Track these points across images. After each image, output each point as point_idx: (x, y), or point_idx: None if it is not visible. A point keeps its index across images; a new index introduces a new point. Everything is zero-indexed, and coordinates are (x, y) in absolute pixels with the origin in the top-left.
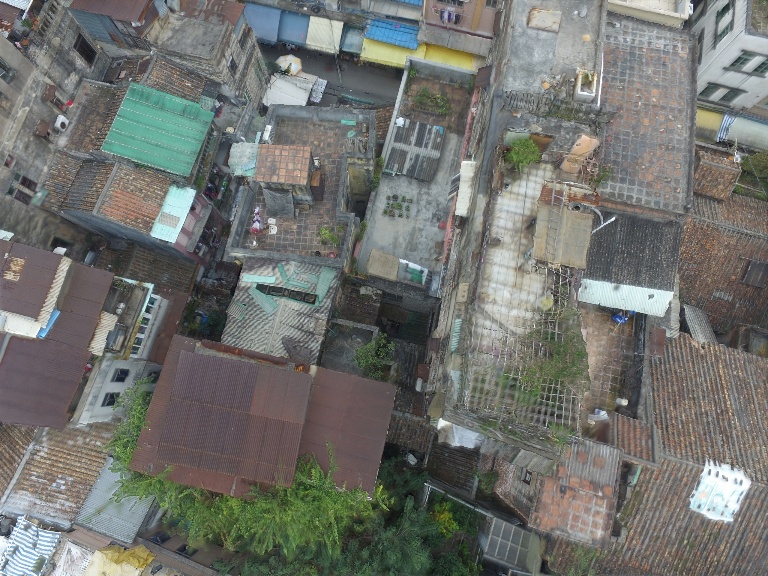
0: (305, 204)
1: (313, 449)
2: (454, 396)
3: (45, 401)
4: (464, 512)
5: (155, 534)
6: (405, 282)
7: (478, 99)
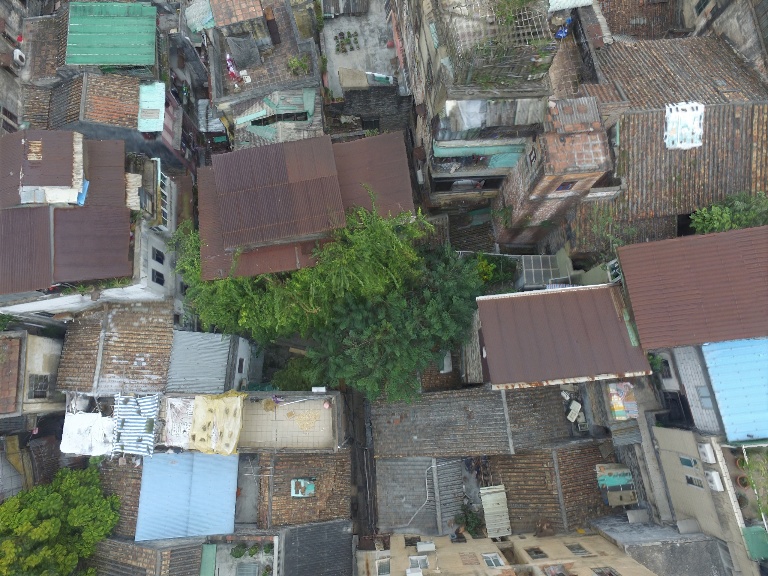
0: (267, 49)
1: (352, 203)
2: (450, 75)
3: (106, 255)
4: (496, 262)
5: None
6: (377, 85)
7: None
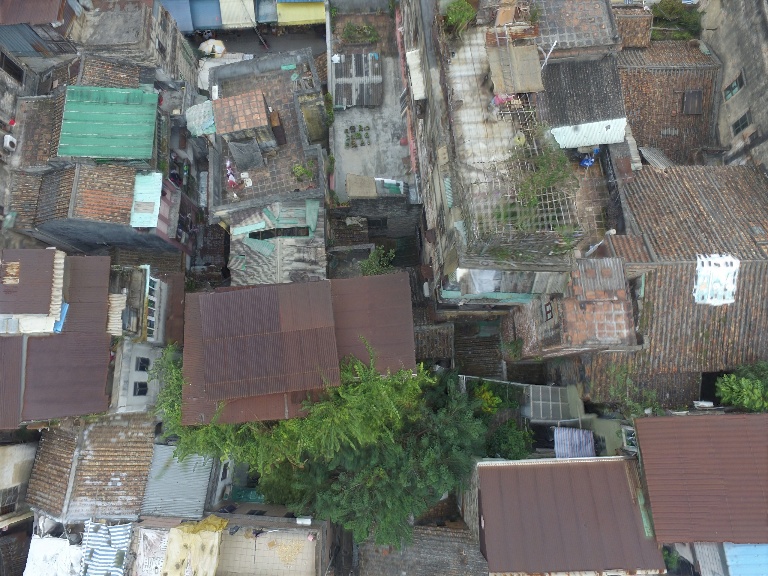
0: (271, 151)
1: (349, 351)
2: (463, 243)
3: (80, 389)
4: (502, 390)
5: (221, 508)
6: (386, 195)
7: (401, 17)
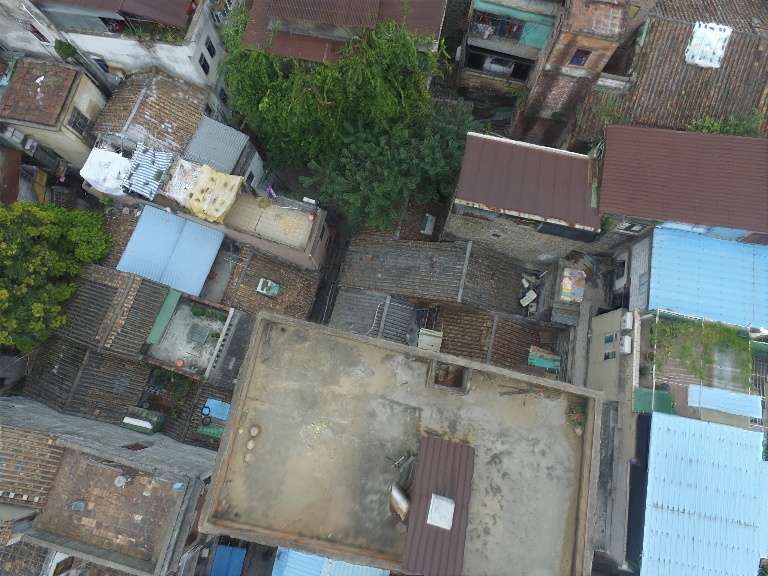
0: None
1: None
2: None
3: (168, 5)
4: None
5: None
6: None
7: None
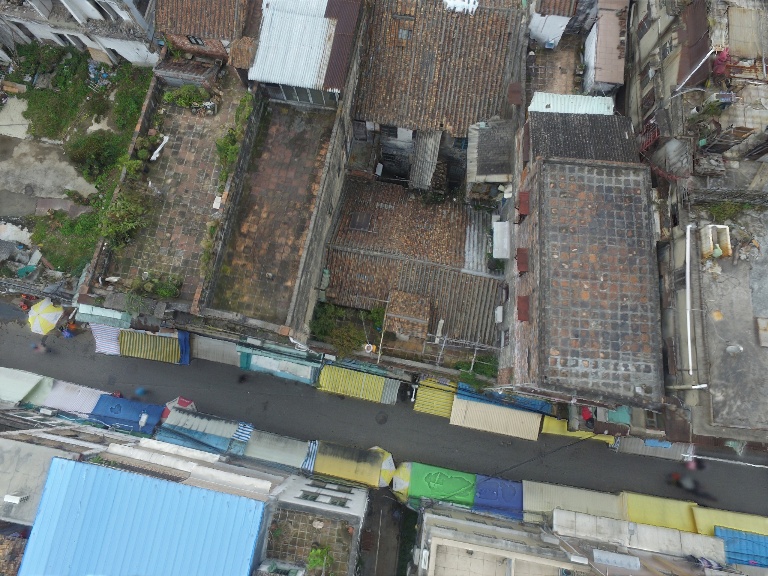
0: None
1: None
2: None
3: None
4: None
5: None
6: None
7: None
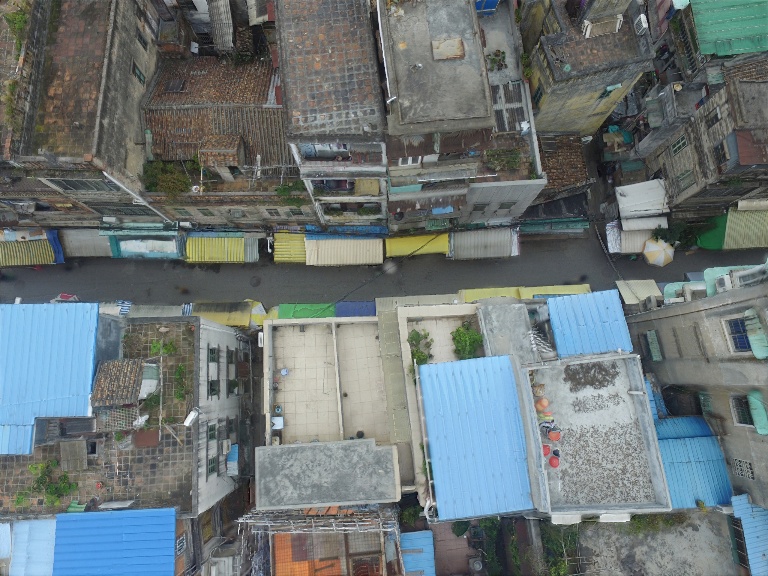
0: None
1: None
2: None
3: None
4: None
5: None
6: None
7: None
